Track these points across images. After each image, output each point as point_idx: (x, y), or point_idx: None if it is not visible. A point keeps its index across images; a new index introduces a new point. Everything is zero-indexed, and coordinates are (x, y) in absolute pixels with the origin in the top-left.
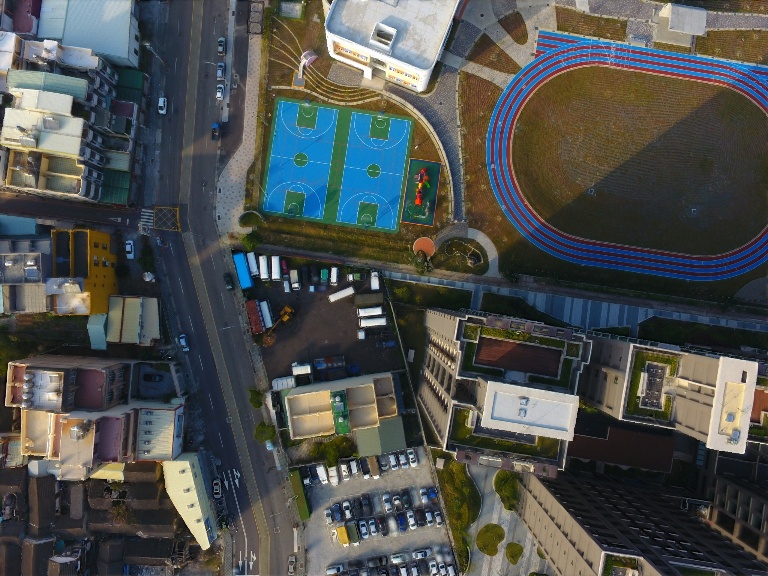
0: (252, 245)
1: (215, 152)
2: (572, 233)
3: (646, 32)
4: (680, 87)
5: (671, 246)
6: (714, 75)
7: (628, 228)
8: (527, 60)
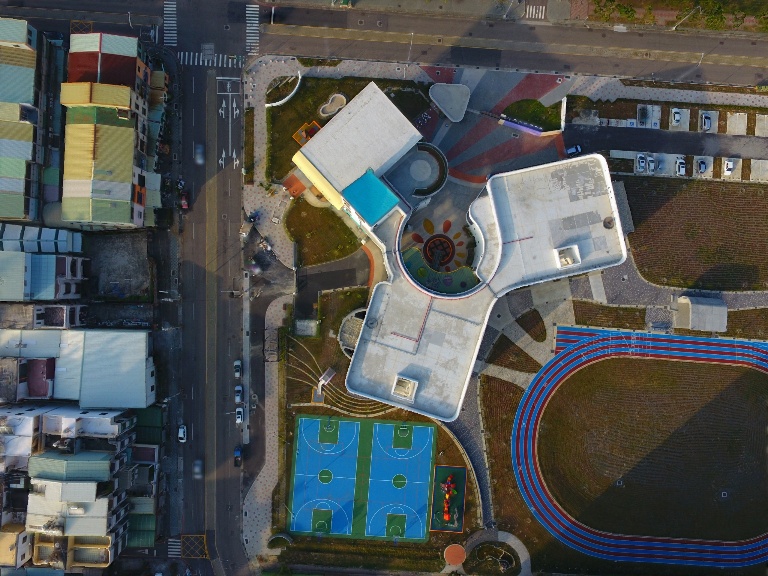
0: None
1: (238, 475)
2: (603, 529)
3: (665, 318)
4: (703, 371)
5: (703, 534)
6: (737, 356)
7: (659, 518)
8: (547, 357)
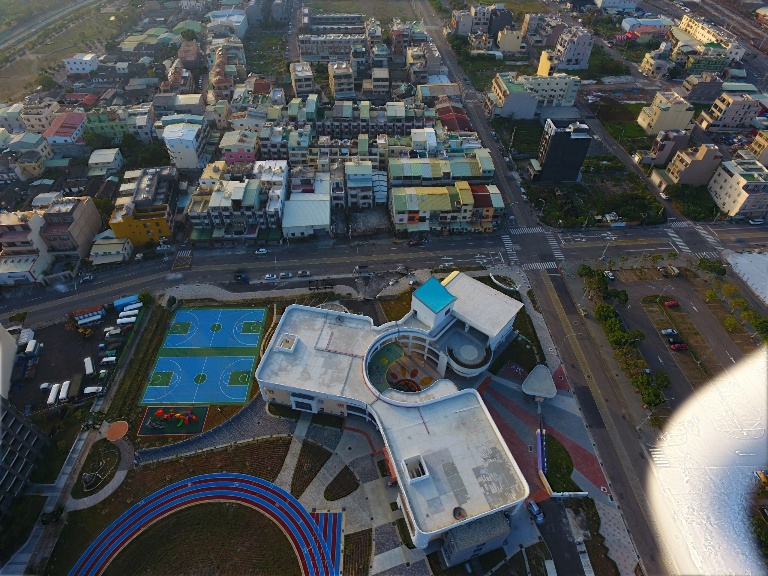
0: (141, 297)
1: (227, 280)
2: None
3: None
4: None
5: None
6: None
7: None
8: (307, 504)
